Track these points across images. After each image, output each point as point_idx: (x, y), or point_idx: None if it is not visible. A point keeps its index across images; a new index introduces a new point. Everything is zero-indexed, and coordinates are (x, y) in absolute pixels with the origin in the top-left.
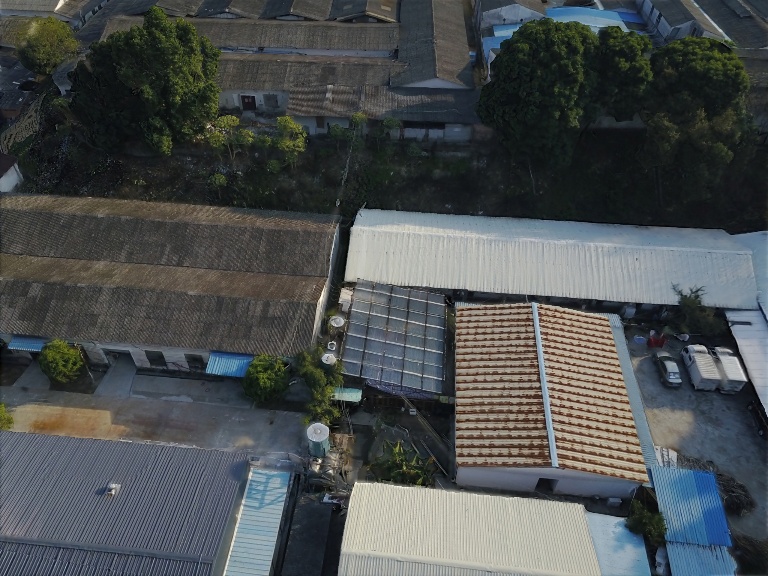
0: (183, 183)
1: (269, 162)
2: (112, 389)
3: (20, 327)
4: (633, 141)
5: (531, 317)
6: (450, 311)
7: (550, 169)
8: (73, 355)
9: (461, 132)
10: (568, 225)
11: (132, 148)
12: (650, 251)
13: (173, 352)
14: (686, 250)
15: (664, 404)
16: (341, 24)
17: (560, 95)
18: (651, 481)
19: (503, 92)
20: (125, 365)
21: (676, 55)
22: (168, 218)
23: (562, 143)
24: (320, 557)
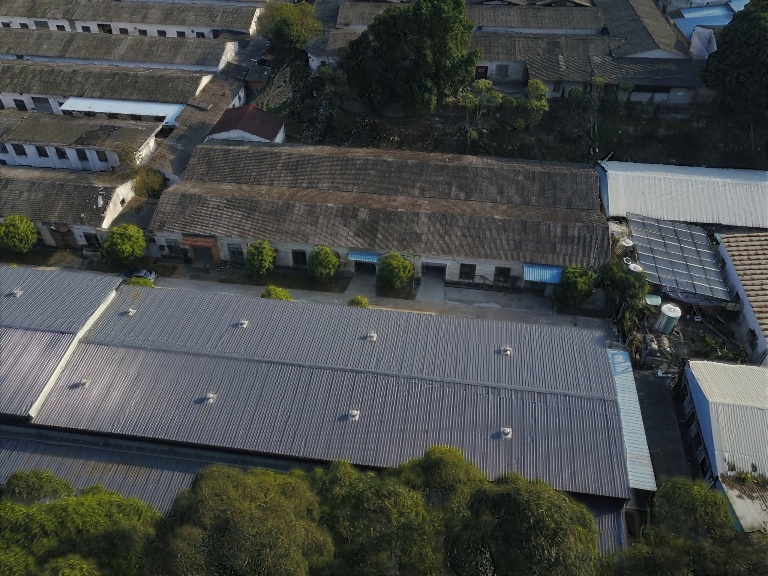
0: (432, 140)
1: (516, 120)
2: (429, 297)
3: (357, 242)
4: None
5: None
6: (712, 240)
7: (766, 129)
8: (409, 264)
9: (683, 96)
10: None
11: (387, 110)
12: None
13: (486, 265)
14: None
15: None
16: (547, 7)
17: None
18: None
19: (738, 56)
20: (434, 279)
21: None
22: (447, 162)
23: None
24: (672, 414)
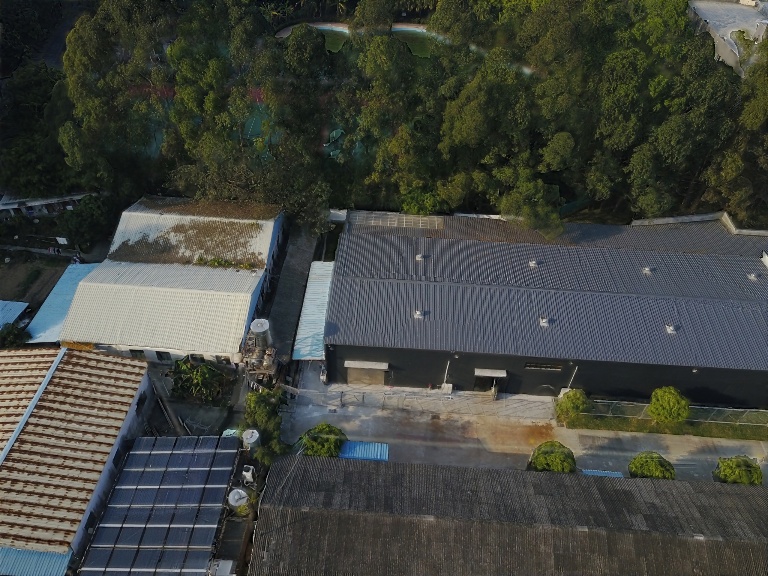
0: None
1: None
2: None
3: (621, 483)
4: None
5: None
6: (78, 561)
7: None
8: (538, 455)
9: None
10: None
11: None
12: None
13: None
14: None
15: None
16: None
17: None
18: None
19: None
20: None
21: None
22: None
23: None
24: (271, 322)
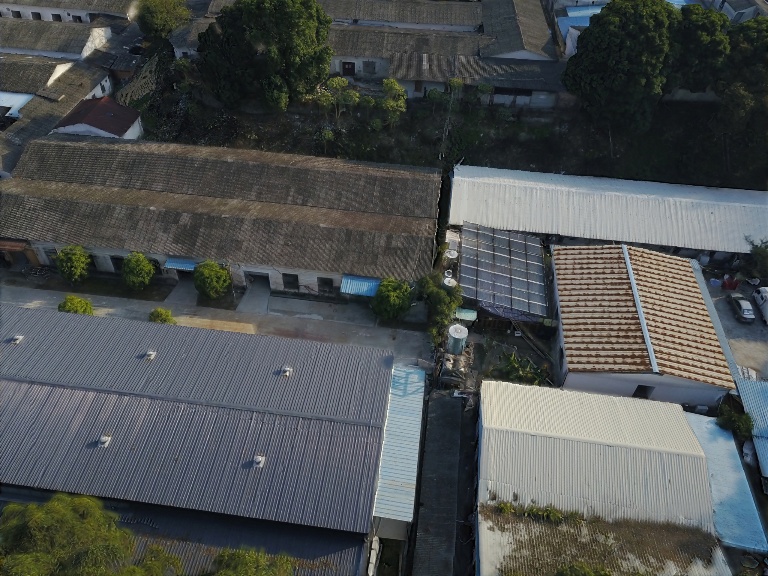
0: (291, 138)
1: (373, 120)
2: (251, 307)
3: (175, 249)
4: (703, 112)
5: (622, 256)
6: (546, 251)
7: (626, 135)
8: (224, 273)
9: (546, 99)
10: (645, 184)
11: (246, 106)
12: (724, 206)
13: (308, 275)
14: (756, 206)
15: (739, 336)
16: (428, 1)
17: (647, 64)
18: (737, 390)
19: (592, 61)
20: (260, 288)
21: (751, 32)
22: (290, 164)
23: (643, 109)
24: (457, 437)
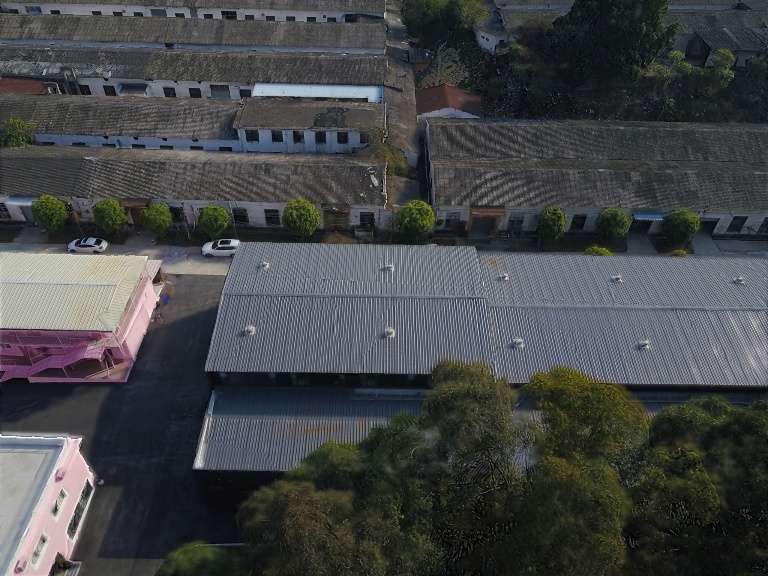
0: (623, 110)
1: (705, 88)
2: (705, 250)
3: (641, 203)
4: None
5: None
6: None
7: None
8: None
9: None
10: None
11: None
12: None
13: (757, 216)
14: None
15: None
16: None
17: None
18: None
19: None
20: (700, 234)
21: None
22: None
23: None
24: None
